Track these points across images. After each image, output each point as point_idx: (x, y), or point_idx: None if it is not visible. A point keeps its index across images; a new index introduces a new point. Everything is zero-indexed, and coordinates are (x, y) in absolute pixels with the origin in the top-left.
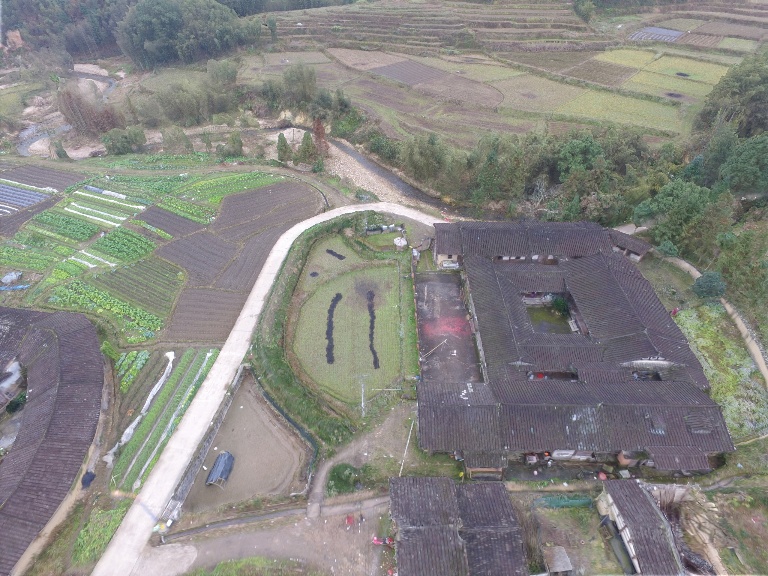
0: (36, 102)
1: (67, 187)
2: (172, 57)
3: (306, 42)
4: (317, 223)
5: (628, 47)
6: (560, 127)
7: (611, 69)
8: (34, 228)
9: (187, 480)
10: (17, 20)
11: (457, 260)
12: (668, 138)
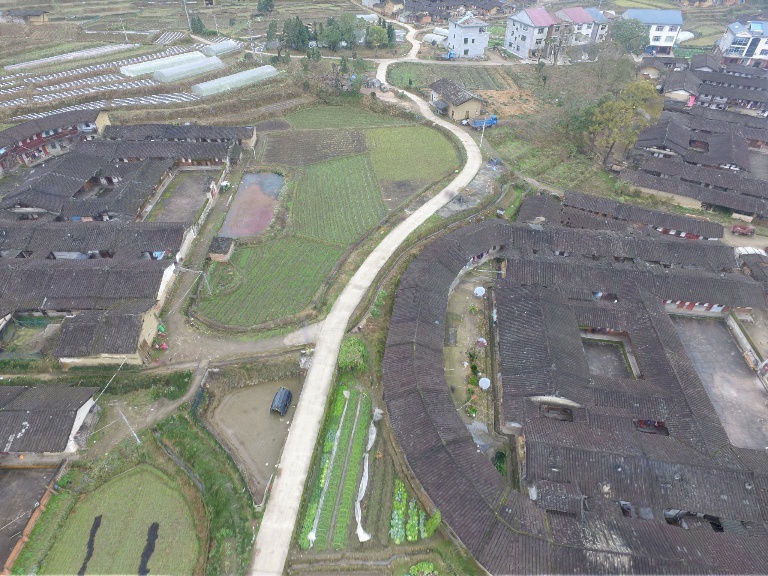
0: None
1: None
2: None
3: None
4: None
5: None
6: None
7: None
8: None
9: None
10: None
11: None
12: None
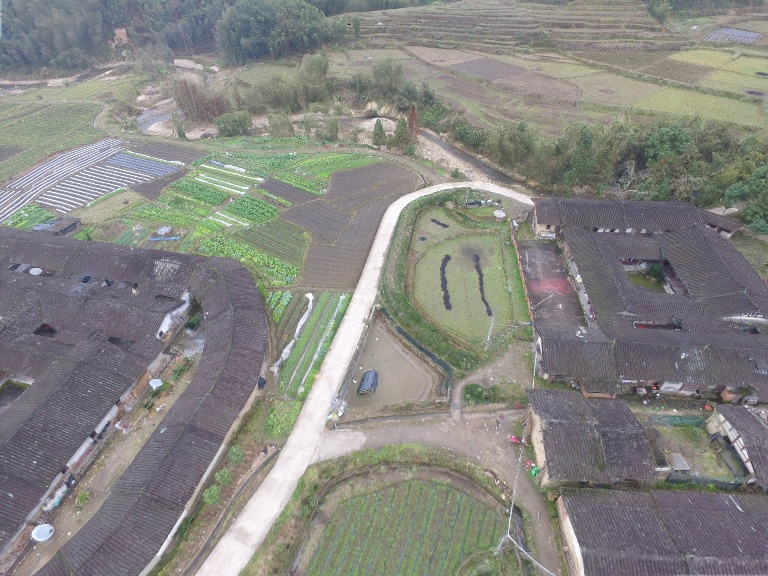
0: (147, 91)
1: (194, 161)
2: (263, 53)
3: (386, 40)
4: (420, 196)
5: (704, 47)
6: (640, 120)
7: (688, 68)
8: (173, 193)
9: (344, 387)
10: (125, 19)
11: (554, 231)
12: (750, 133)
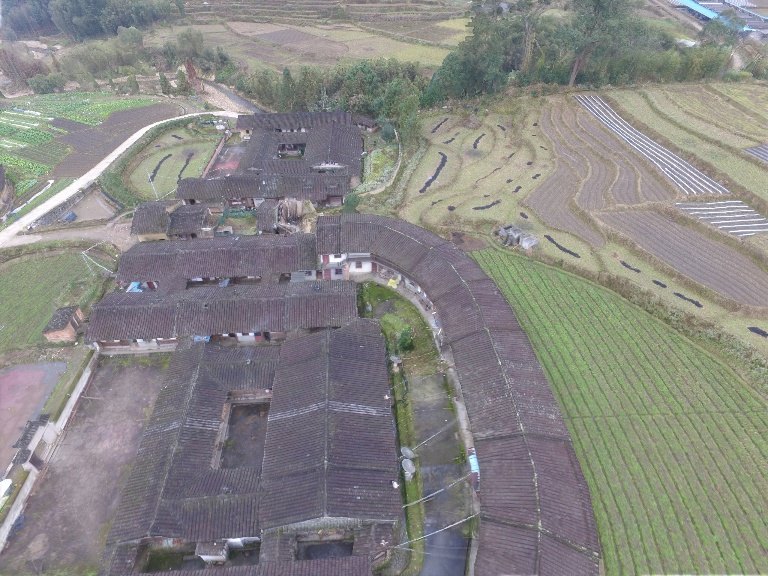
0: None
1: None
2: (99, 31)
3: (210, 17)
4: None
5: None
6: None
7: (444, 31)
8: None
9: (45, 220)
10: None
11: None
12: None
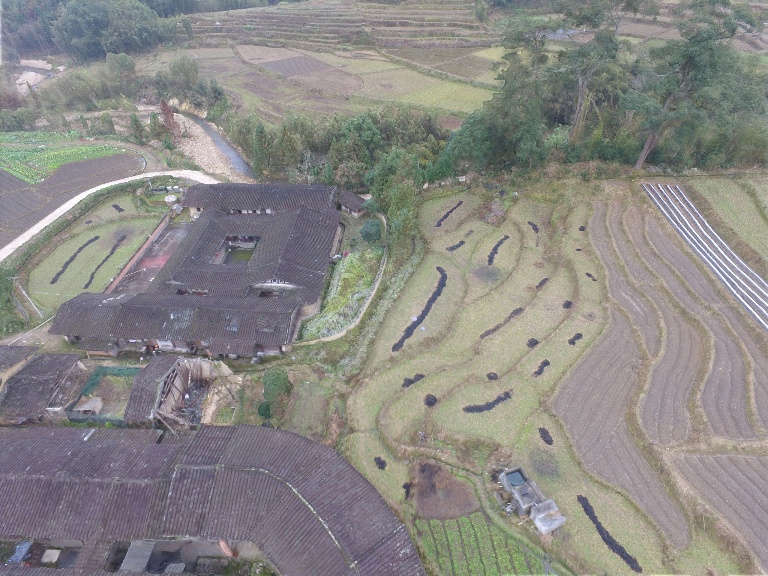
0: None
1: None
2: (101, 53)
3: (221, 40)
4: None
5: None
6: None
7: (481, 63)
8: None
9: None
10: None
11: None
12: None
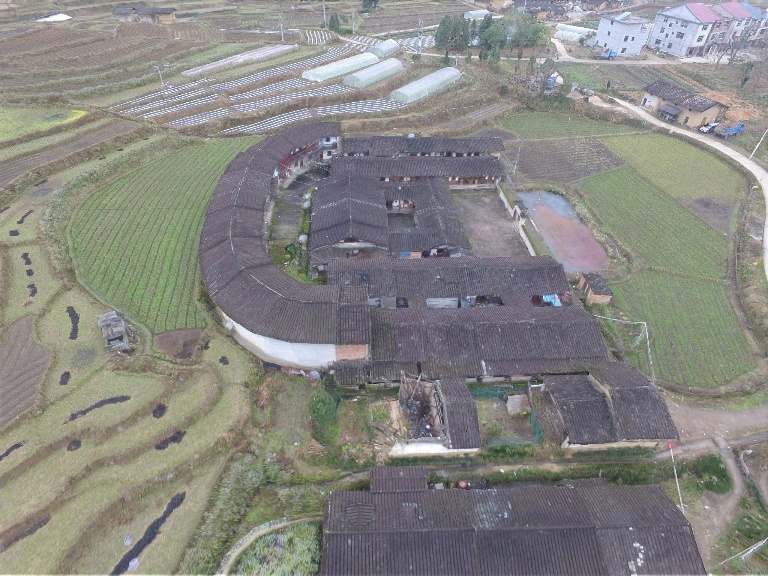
0: None
1: None
2: None
3: None
4: None
5: None
6: None
7: None
8: None
9: None
10: None
11: None
12: None
